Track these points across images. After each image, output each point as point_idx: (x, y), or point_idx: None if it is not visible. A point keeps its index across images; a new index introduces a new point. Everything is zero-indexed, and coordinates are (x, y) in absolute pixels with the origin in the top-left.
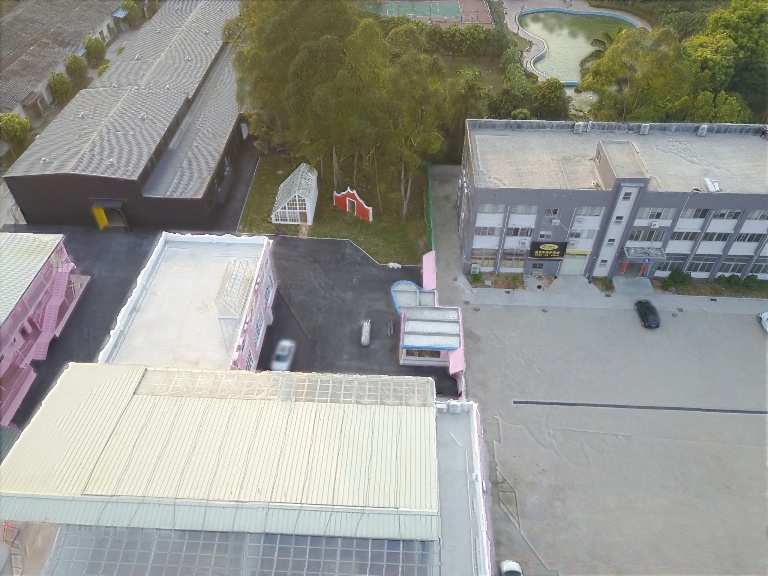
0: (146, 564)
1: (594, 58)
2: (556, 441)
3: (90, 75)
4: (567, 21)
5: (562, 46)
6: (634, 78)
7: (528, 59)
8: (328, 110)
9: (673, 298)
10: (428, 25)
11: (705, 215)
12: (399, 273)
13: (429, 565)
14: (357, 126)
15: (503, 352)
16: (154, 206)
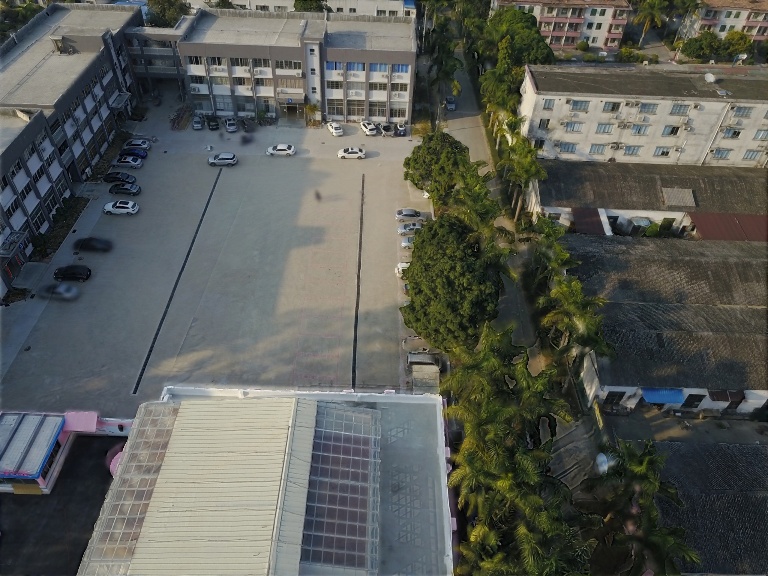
0: None
1: None
2: (186, 368)
3: None
4: None
5: None
6: None
7: None
8: None
9: (59, 254)
10: None
11: (6, 182)
12: None
13: (335, 412)
14: None
15: (68, 394)
16: None
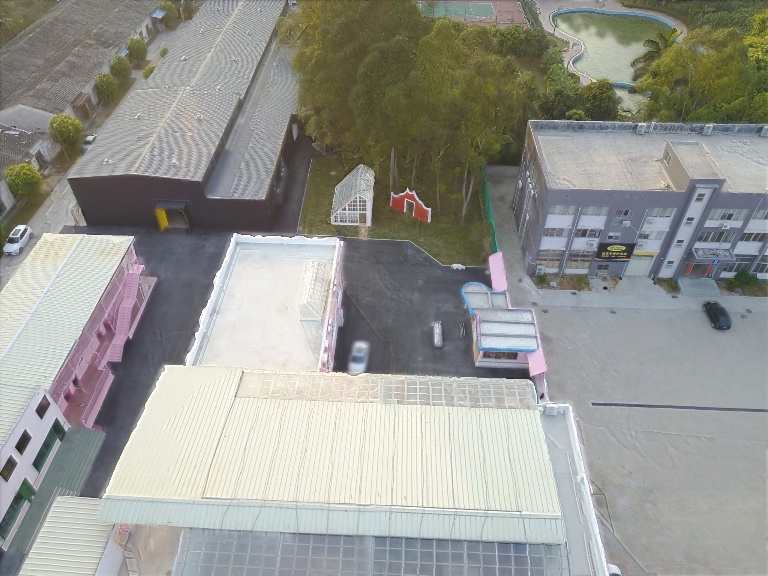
0: (274, 568)
1: (647, 59)
2: (639, 443)
3: (132, 76)
4: (601, 21)
5: (599, 46)
6: (695, 79)
7: (567, 59)
8: (399, 111)
9: (740, 299)
10: (468, 25)
11: None
12: (464, 274)
13: (558, 569)
14: (429, 127)
15: (576, 354)
16: (216, 207)
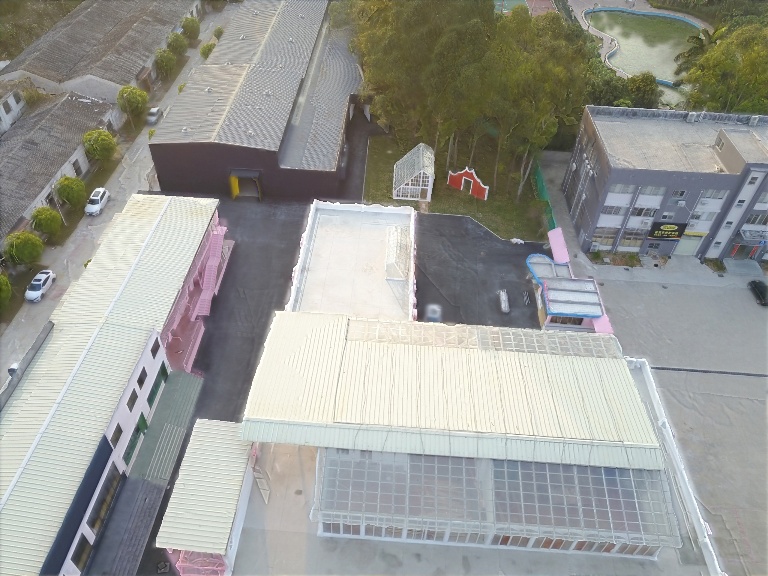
0: (405, 483)
1: (690, 54)
2: (697, 403)
3: (185, 54)
4: (631, 20)
5: (631, 44)
6: (742, 73)
7: (602, 55)
8: (474, 90)
9: None
10: None
11: None
12: (523, 248)
13: (660, 491)
14: (502, 106)
15: (633, 323)
16: (288, 177)
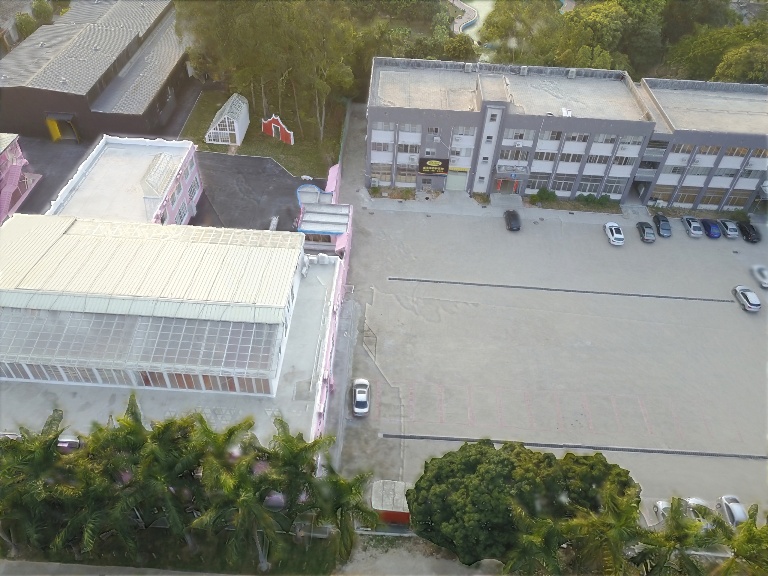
0: (61, 333)
1: None
2: (417, 305)
3: (55, 20)
4: None
5: None
6: (519, 29)
7: (458, 25)
8: (247, 37)
9: (538, 211)
10: None
11: (560, 137)
12: None
13: (273, 339)
14: (271, 51)
15: (387, 244)
16: (101, 121)
